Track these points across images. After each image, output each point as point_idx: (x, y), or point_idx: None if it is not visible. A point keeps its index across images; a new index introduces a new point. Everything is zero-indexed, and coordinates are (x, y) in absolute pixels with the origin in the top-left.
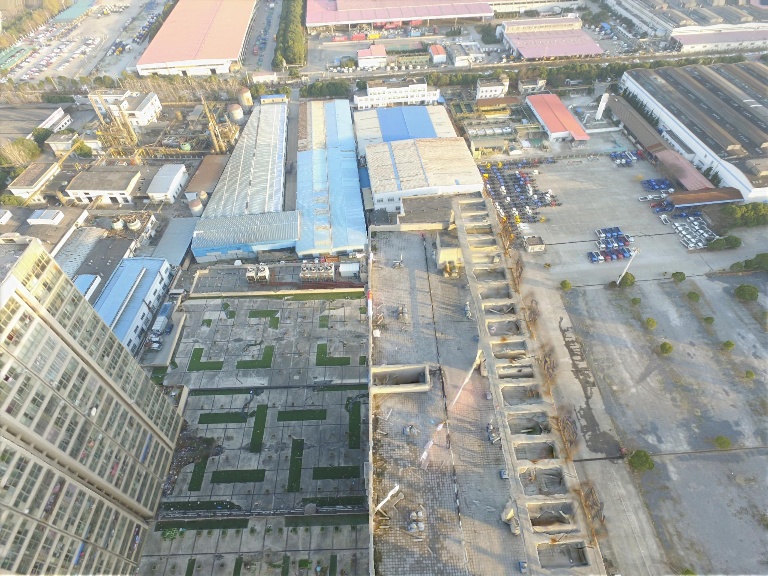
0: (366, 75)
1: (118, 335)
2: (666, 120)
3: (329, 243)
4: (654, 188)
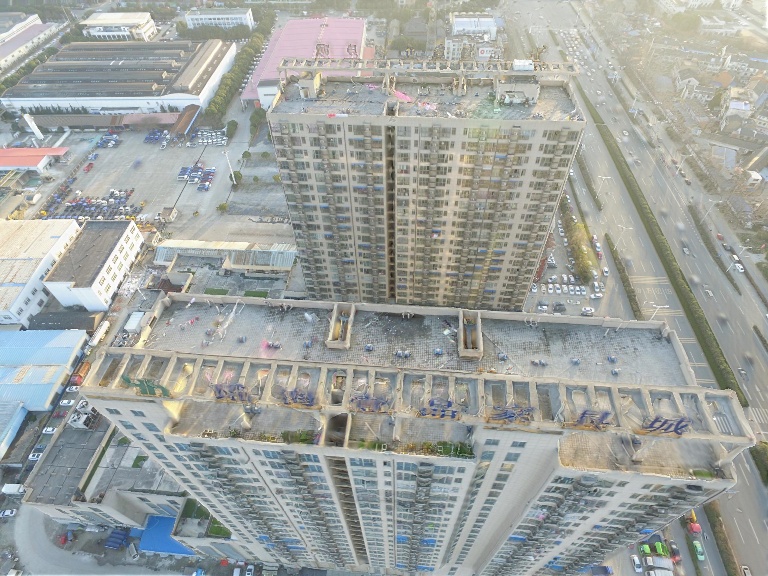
0: None
1: None
2: (89, 104)
3: (55, 368)
4: (157, 138)
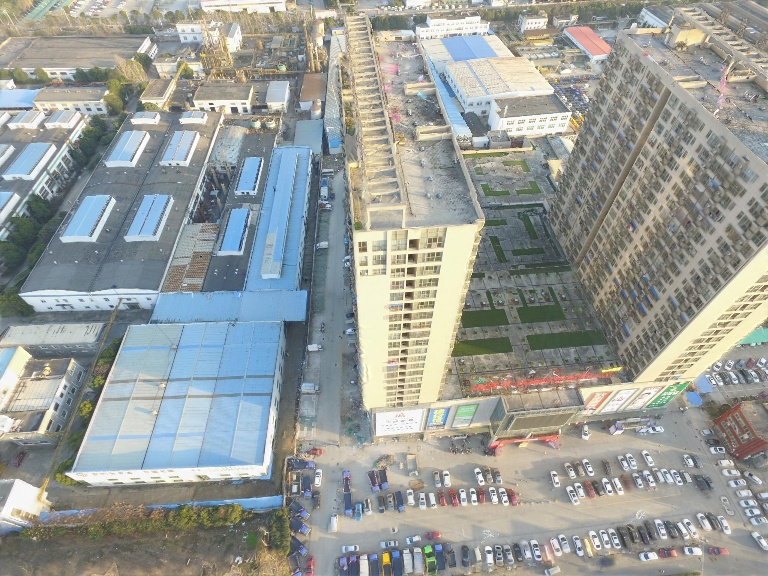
0: (417, 12)
1: (298, 198)
2: None
3: None
4: None
